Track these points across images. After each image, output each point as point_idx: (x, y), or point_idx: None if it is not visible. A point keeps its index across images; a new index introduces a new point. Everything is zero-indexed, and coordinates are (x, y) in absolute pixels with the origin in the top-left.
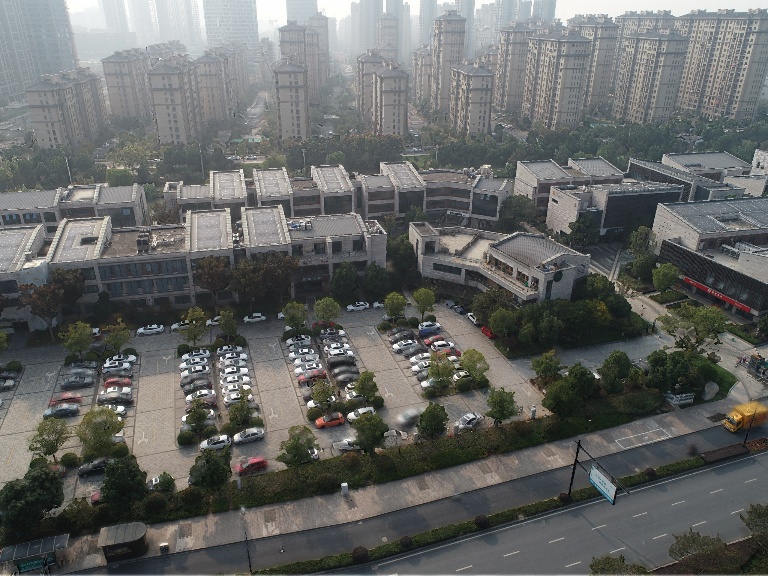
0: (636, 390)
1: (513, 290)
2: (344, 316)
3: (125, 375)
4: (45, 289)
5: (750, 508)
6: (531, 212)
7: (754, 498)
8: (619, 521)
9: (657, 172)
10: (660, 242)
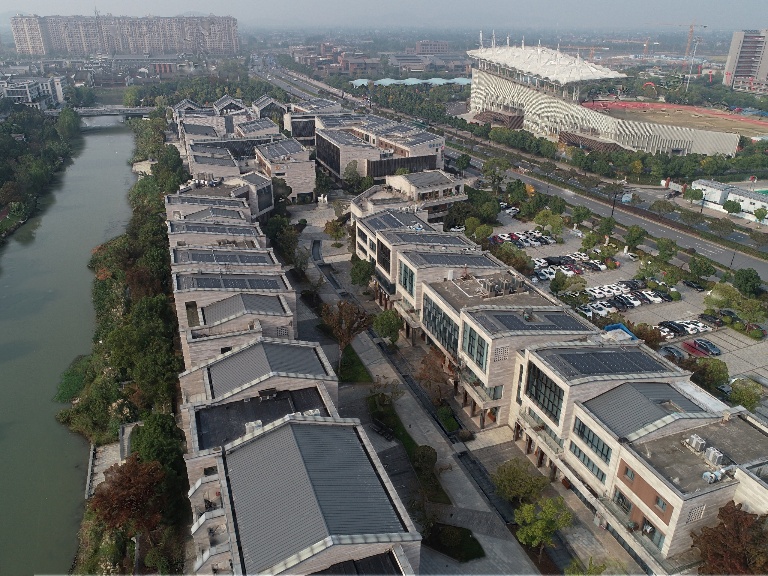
0: (518, 204)
1: (458, 199)
2: None
3: None
4: (640, 328)
5: (609, 187)
6: None
7: None
8: None
9: (231, 142)
10: None
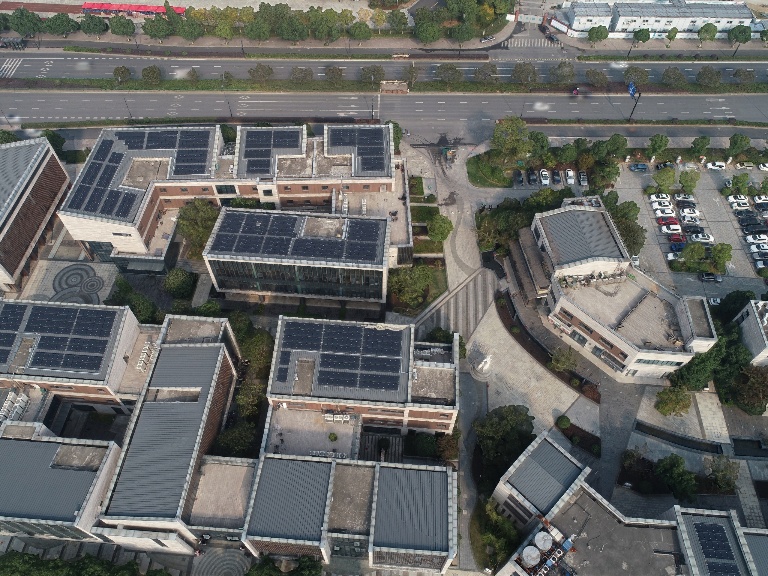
0: None
1: None
2: (760, 297)
3: None
4: None
5: None
6: (493, 412)
7: (538, 105)
8: (609, 112)
9: None
10: None
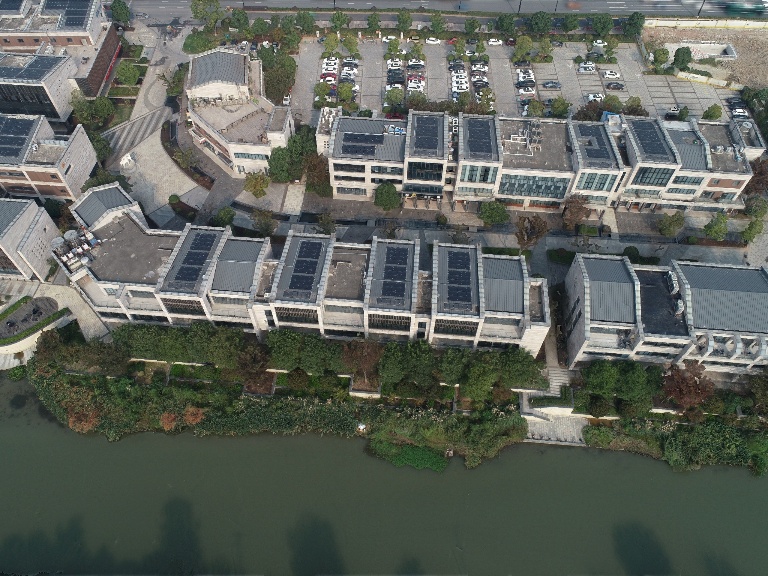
0: None
1: None
2: None
3: (525, 100)
4: (593, 105)
5: None
6: None
7: None
8: (324, 3)
9: None
10: (65, 102)
